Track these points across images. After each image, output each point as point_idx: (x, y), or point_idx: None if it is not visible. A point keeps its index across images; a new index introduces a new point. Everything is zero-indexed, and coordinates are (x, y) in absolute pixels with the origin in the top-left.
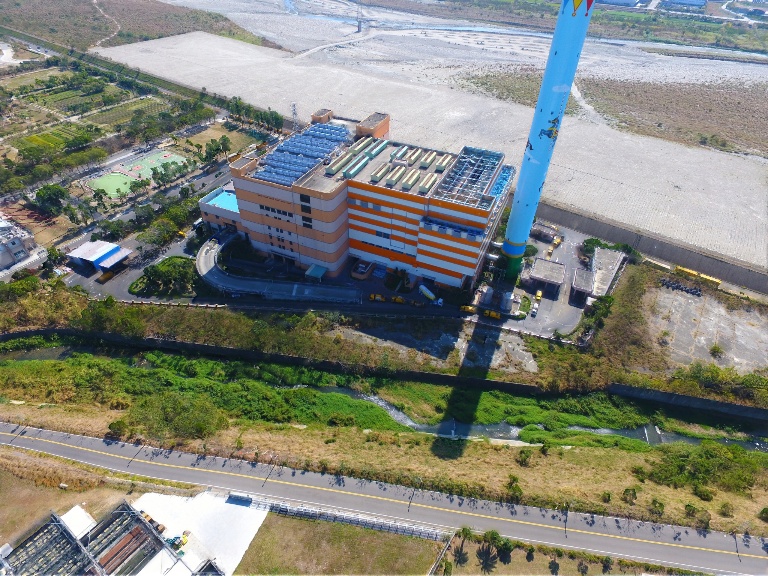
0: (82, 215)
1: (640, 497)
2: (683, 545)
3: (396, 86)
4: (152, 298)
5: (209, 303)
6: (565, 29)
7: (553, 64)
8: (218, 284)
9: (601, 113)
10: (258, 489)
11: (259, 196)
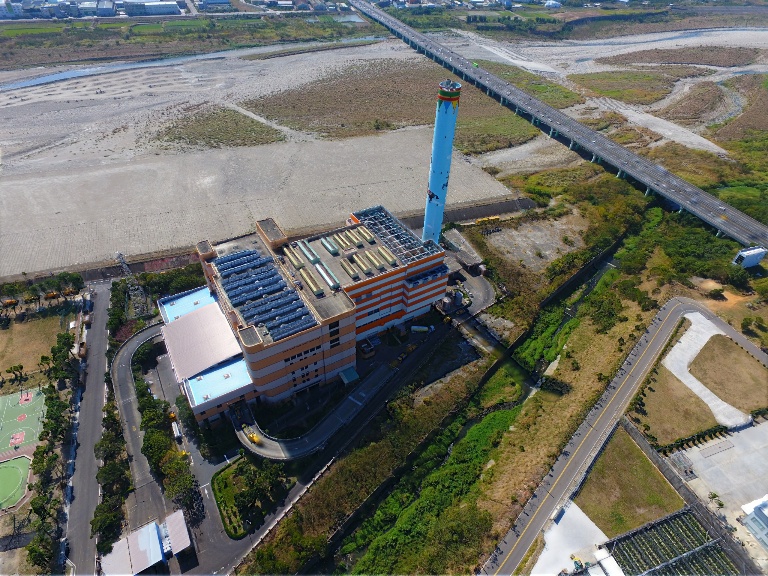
0: (43, 547)
1: None
2: (650, 342)
3: (103, 176)
4: (267, 519)
5: (316, 471)
6: (449, 122)
7: (444, 143)
8: (308, 451)
9: (299, 130)
10: (554, 501)
11: (284, 352)
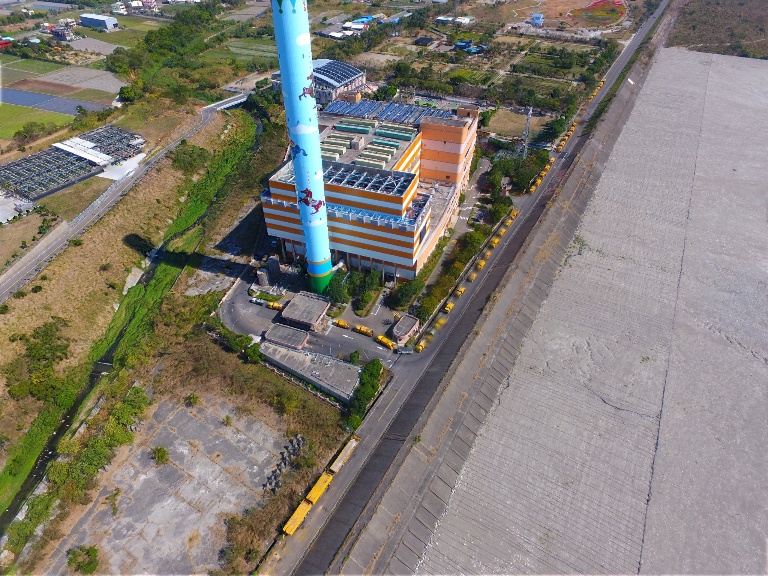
0: None
1: (37, 300)
2: None
3: None
4: None
5: (289, 159)
6: None
7: None
8: None
9: None
10: None
11: None
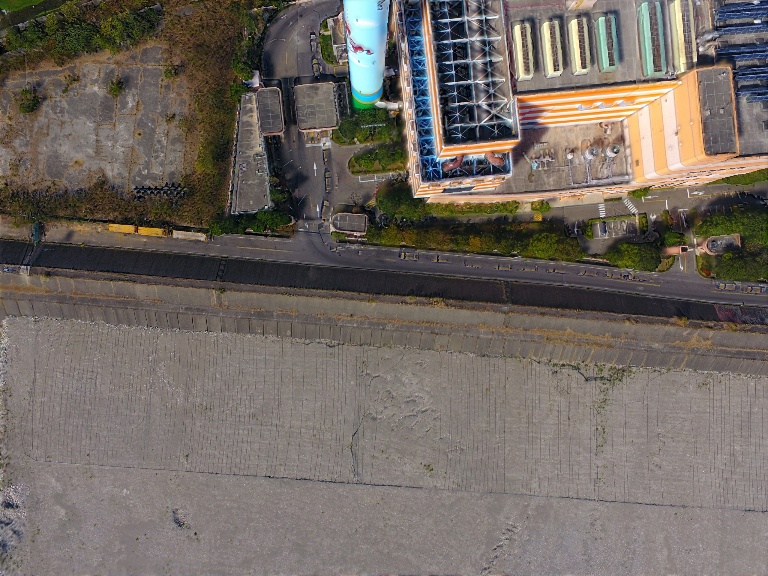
0: None
1: None
2: None
3: None
4: None
5: None
6: None
7: None
8: None
9: None
10: None
11: None
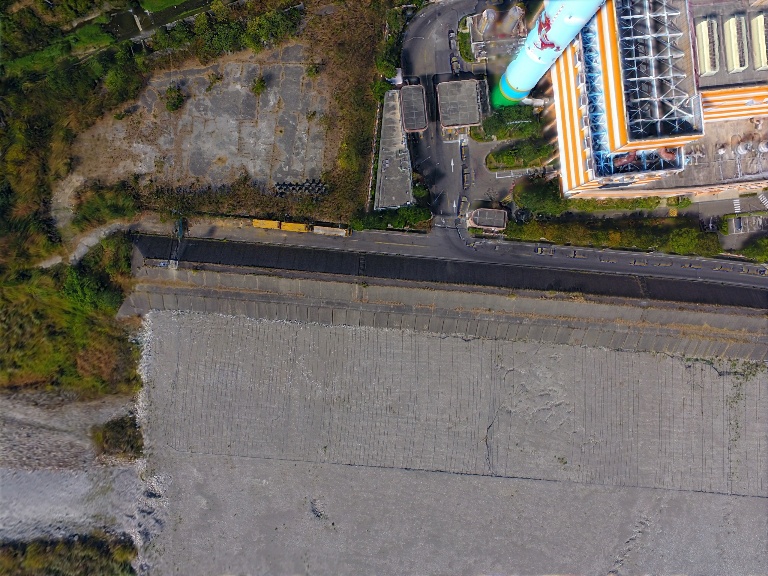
0: None
1: None
2: None
3: None
4: None
5: None
6: None
7: None
8: None
9: None
10: None
11: None
